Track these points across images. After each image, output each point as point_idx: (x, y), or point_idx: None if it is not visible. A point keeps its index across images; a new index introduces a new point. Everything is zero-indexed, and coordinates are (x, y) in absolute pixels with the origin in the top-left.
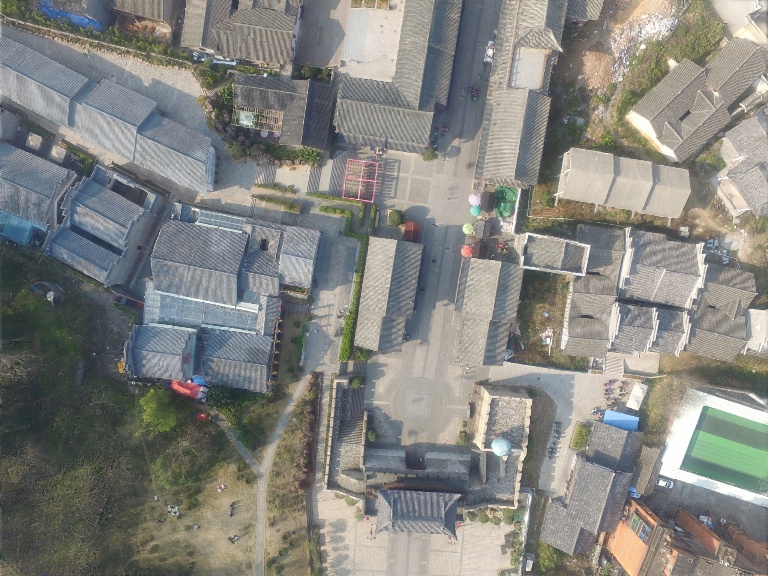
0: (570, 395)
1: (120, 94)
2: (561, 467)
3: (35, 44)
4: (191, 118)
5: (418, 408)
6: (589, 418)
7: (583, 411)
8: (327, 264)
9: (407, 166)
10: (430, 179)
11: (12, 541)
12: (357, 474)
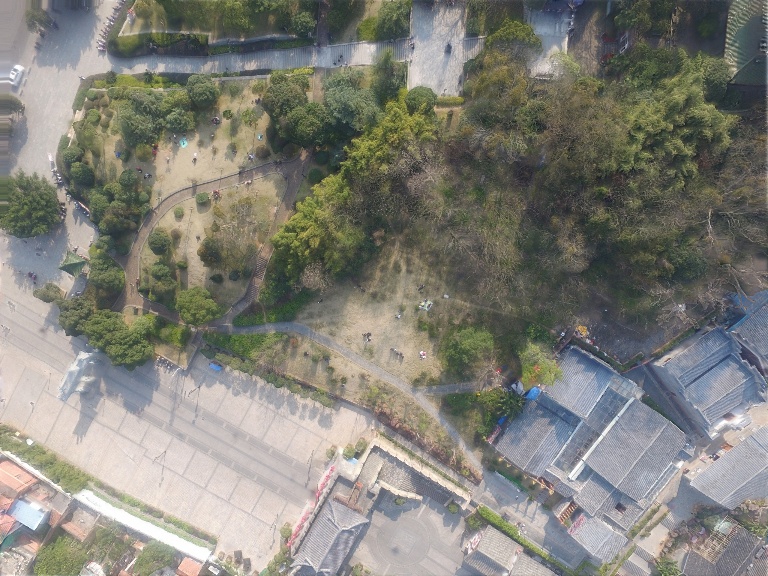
0: None
1: None
2: None
3: None
4: None
5: (401, 539)
6: None
7: None
8: None
9: None
10: None
11: None
12: None
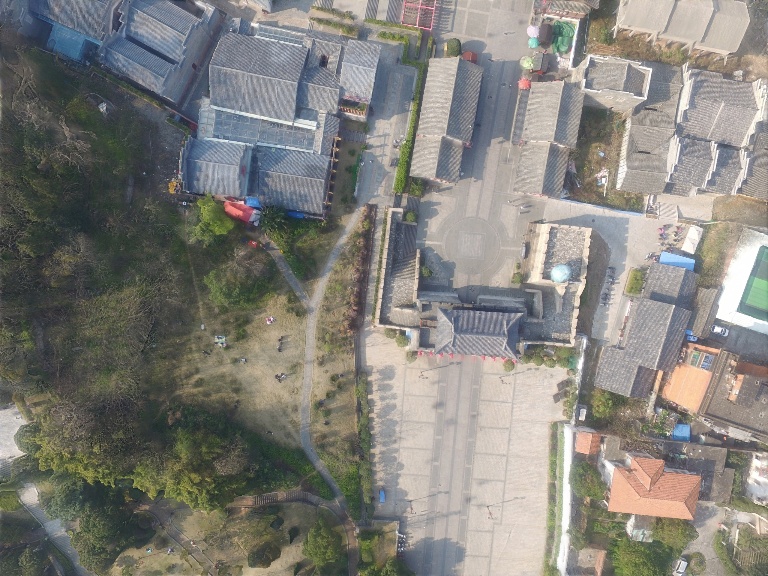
0: (624, 240)
1: None
2: (614, 315)
3: None
4: None
5: (471, 249)
6: (643, 264)
7: (637, 257)
8: (384, 92)
9: None
10: (487, 13)
11: (52, 364)
12: (410, 308)
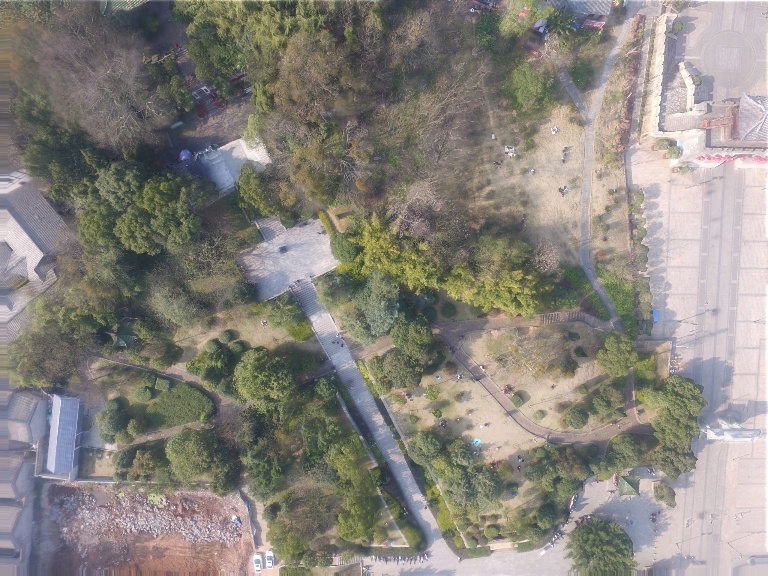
0: None
1: None
2: None
3: None
4: None
5: (728, 62)
6: None
7: None
8: None
9: None
10: None
11: None
12: None
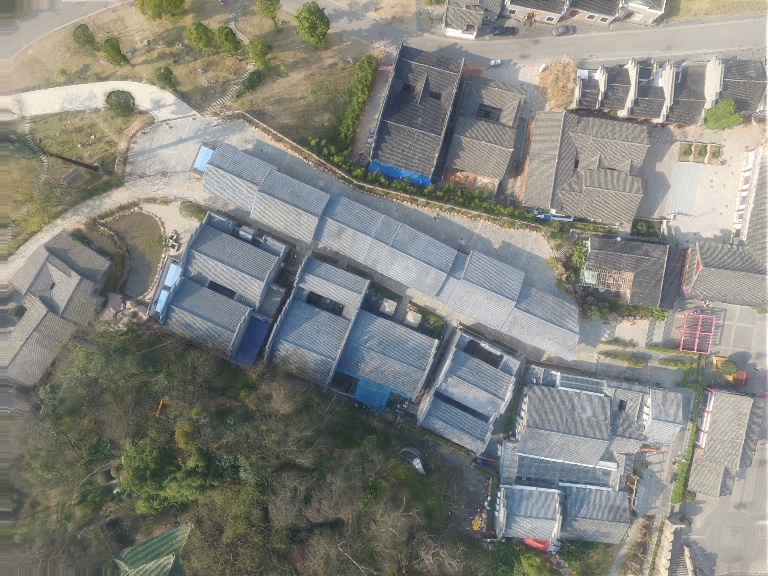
0: None
1: (491, 266)
2: None
3: (382, 207)
4: (540, 279)
5: (732, 541)
6: None
7: None
8: None
9: (732, 314)
10: (753, 326)
11: None
12: None
